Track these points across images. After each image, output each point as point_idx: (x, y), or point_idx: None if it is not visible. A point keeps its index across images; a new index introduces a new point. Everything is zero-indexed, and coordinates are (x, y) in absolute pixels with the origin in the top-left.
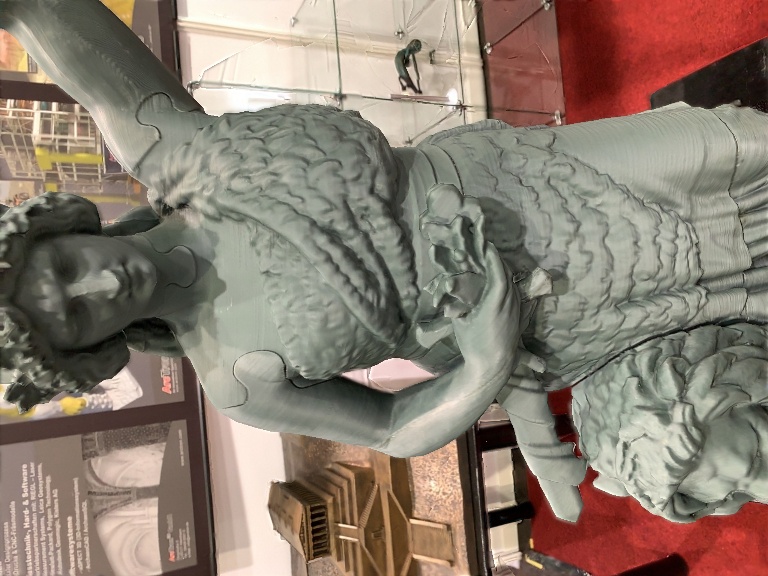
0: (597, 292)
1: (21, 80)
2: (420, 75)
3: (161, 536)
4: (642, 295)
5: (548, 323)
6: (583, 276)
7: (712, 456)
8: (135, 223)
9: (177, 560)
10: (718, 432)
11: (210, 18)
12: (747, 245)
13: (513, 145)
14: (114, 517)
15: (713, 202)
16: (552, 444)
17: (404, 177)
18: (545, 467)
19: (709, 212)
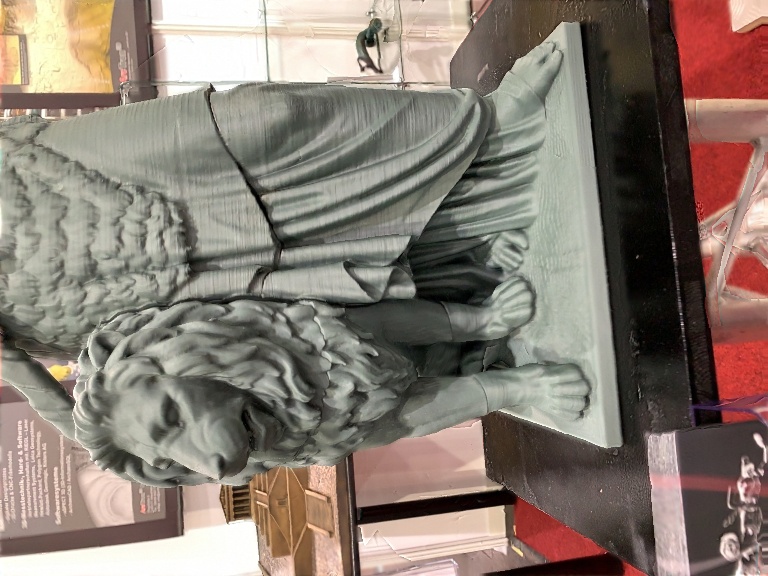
0: (45, 270)
1: (15, 92)
2: (381, 54)
3: (134, 490)
4: (110, 273)
5: (7, 299)
6: (29, 256)
7: (123, 423)
8: None
9: (148, 513)
10: (128, 401)
11: (183, 19)
12: (284, 222)
13: None
14: (93, 470)
15: (216, 181)
16: (59, 408)
17: None
18: (64, 429)
19: (207, 192)
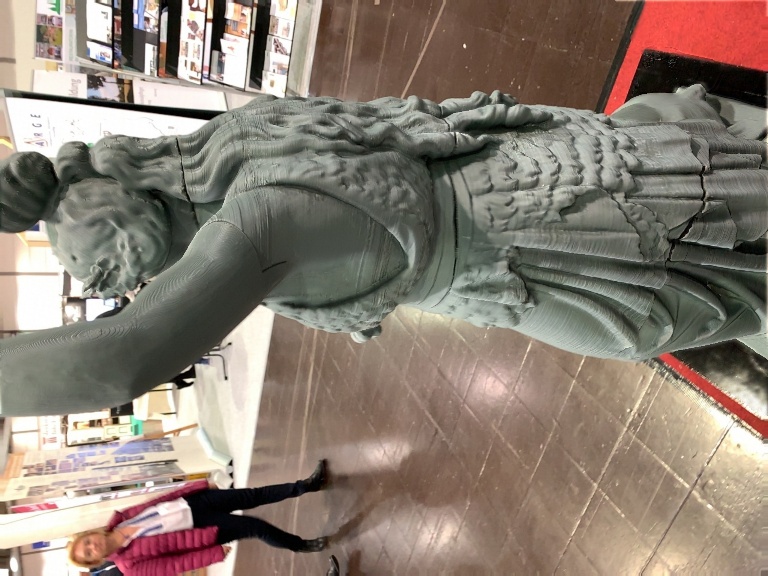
0: None
1: None
2: None
3: None
4: None
5: None
6: None
7: None
8: (204, 203)
9: None
10: None
11: None
12: None
13: None
14: None
15: None
16: None
17: None
18: None
19: None
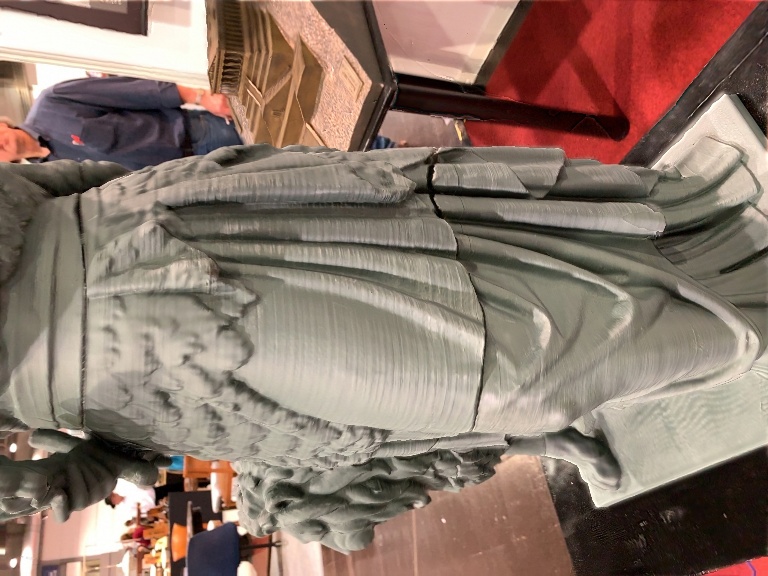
0: None
1: None
2: None
3: None
4: None
5: None
6: None
7: None
8: None
9: (106, 2)
10: None
11: None
12: None
13: (174, 366)
14: None
15: None
16: None
17: (4, 376)
18: None
19: None
